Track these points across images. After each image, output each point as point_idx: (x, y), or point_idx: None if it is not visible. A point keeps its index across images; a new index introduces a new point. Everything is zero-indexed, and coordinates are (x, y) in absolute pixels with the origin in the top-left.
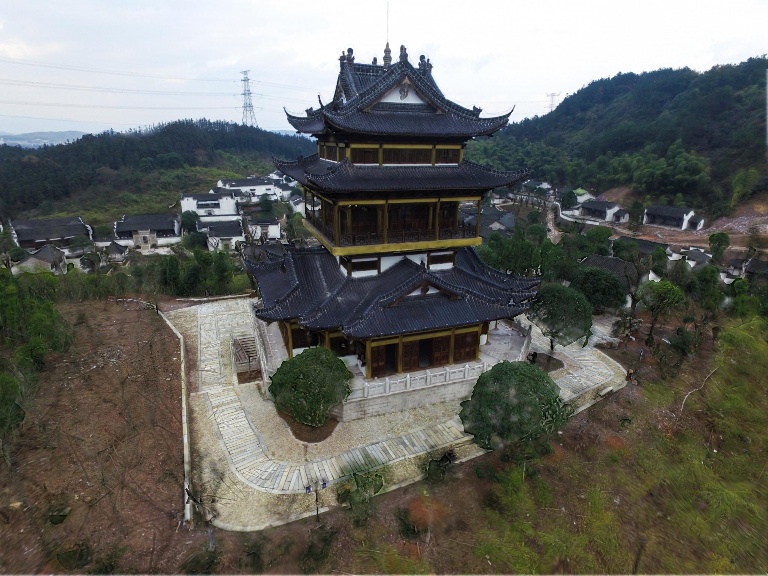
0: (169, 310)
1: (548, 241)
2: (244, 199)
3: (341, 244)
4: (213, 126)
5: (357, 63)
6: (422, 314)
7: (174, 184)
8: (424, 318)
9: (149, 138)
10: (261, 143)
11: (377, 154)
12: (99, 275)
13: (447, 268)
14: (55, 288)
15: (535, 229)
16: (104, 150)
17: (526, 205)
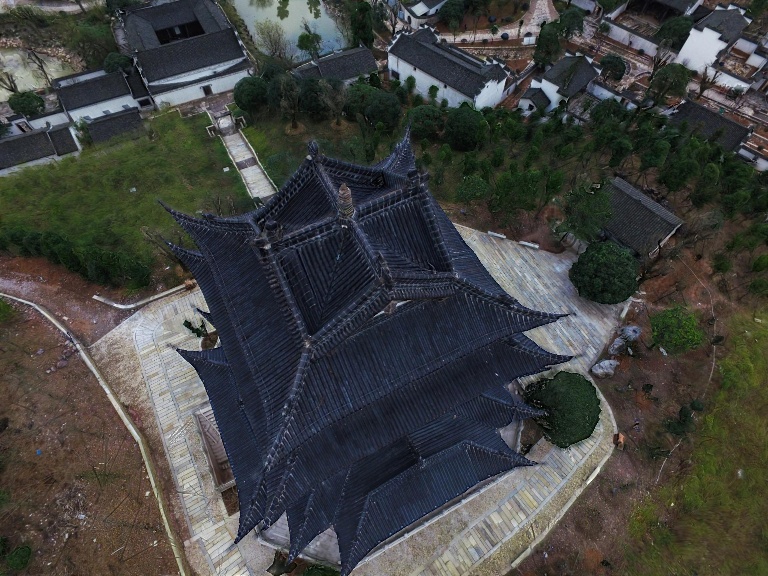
0: (95, 337)
1: (559, 176)
2: None
3: None
4: None
5: (289, 235)
6: (419, 492)
7: None
8: (422, 498)
9: None
10: None
11: None
12: None
13: None
14: None
15: None
16: None
17: None
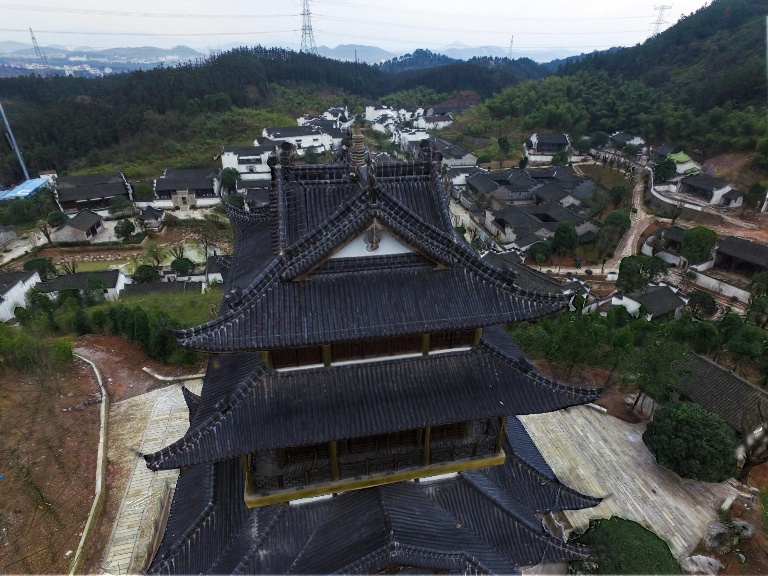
0: (123, 397)
1: (627, 331)
2: None
3: (259, 489)
4: (269, 54)
5: (300, 165)
6: None
7: (220, 130)
8: None
9: (199, 74)
10: (318, 74)
11: (320, 350)
12: (40, 353)
13: (448, 476)
14: (0, 358)
15: (616, 218)
16: (153, 89)
17: (610, 167)
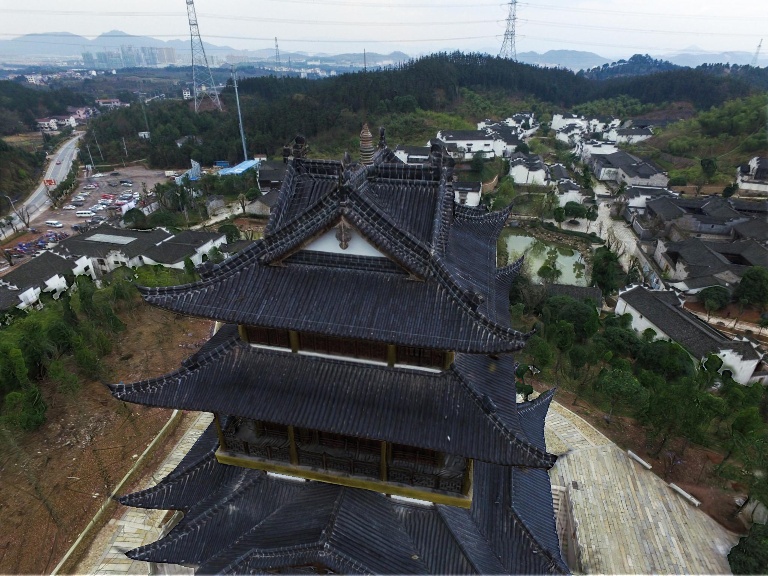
0: None
1: (751, 414)
2: (457, 155)
3: (229, 449)
4: (465, 59)
5: (312, 159)
6: None
7: (400, 130)
8: None
9: (395, 77)
10: (511, 79)
11: (288, 335)
12: None
13: (423, 503)
14: None
15: None
16: (353, 90)
17: None
